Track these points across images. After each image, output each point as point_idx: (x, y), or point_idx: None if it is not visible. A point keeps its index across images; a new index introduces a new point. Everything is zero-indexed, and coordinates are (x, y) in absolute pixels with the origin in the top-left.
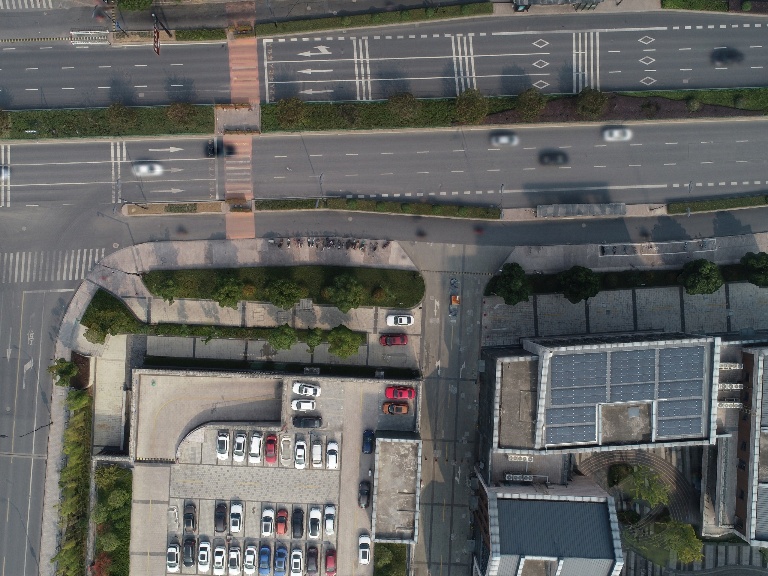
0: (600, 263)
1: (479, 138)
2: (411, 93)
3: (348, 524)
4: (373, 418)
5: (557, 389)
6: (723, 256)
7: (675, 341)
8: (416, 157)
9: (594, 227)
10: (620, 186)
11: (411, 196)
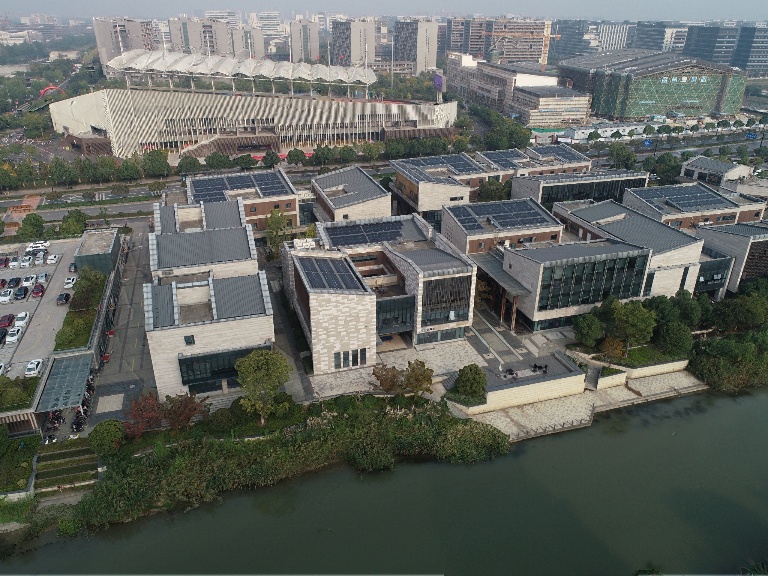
0: None
1: None
2: None
3: None
4: None
5: None
6: None
7: None
8: (129, 208)
9: None
10: None
11: None
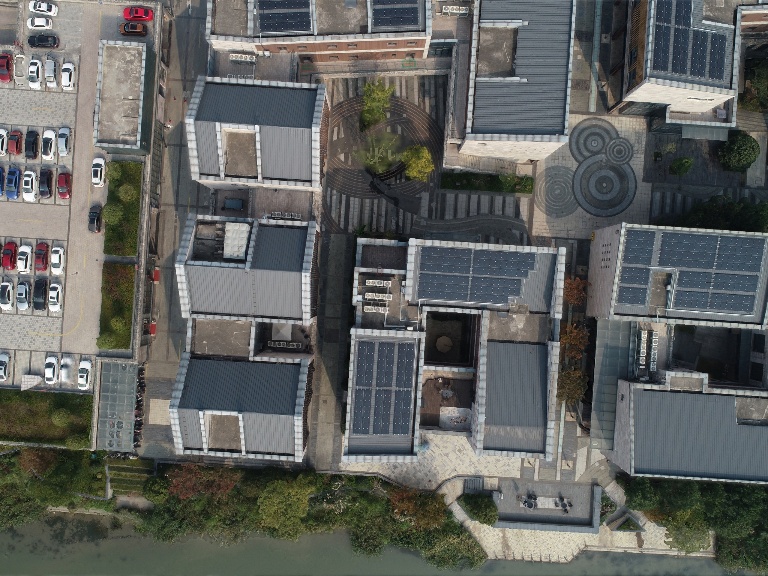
0: None
1: None
2: None
3: (84, 148)
4: None
5: None
6: None
7: None
8: None
9: None
10: None
11: None
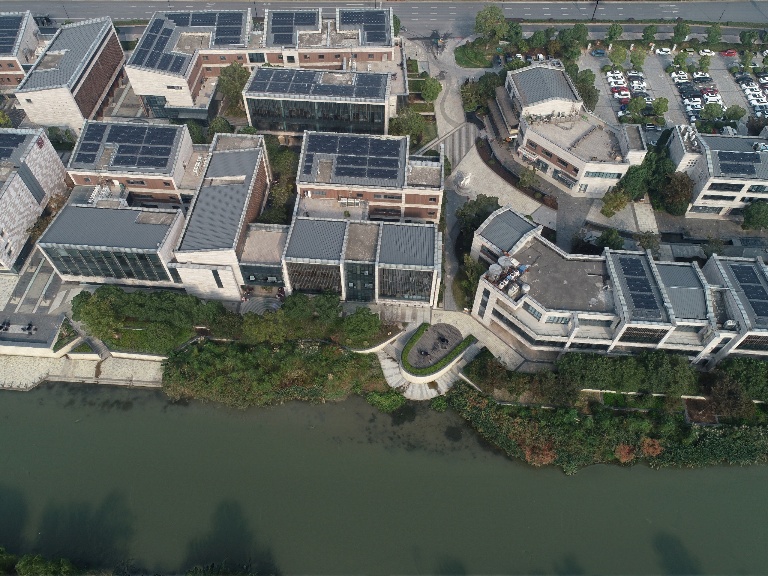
0: None
1: None
2: None
3: None
4: None
5: None
6: None
7: (6, 12)
8: None
9: None
10: (60, 18)
11: None
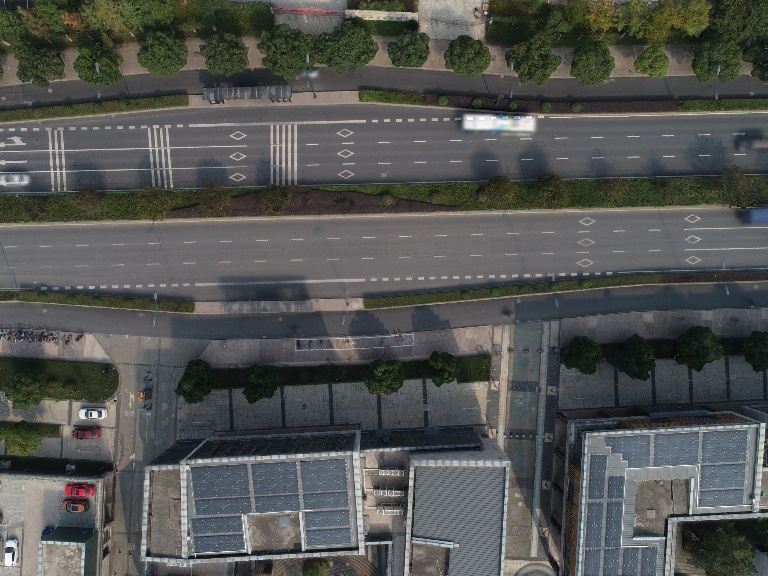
0: (296, 357)
1: (175, 231)
2: (107, 185)
3: None
4: (54, 515)
5: (201, 499)
6: (421, 351)
7: (313, 454)
8: (111, 249)
9: (291, 321)
10: (317, 280)
11: (106, 288)
